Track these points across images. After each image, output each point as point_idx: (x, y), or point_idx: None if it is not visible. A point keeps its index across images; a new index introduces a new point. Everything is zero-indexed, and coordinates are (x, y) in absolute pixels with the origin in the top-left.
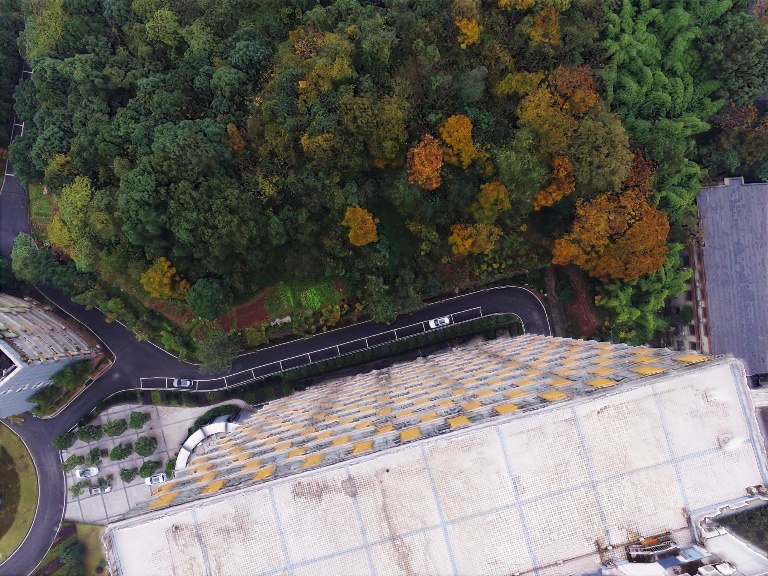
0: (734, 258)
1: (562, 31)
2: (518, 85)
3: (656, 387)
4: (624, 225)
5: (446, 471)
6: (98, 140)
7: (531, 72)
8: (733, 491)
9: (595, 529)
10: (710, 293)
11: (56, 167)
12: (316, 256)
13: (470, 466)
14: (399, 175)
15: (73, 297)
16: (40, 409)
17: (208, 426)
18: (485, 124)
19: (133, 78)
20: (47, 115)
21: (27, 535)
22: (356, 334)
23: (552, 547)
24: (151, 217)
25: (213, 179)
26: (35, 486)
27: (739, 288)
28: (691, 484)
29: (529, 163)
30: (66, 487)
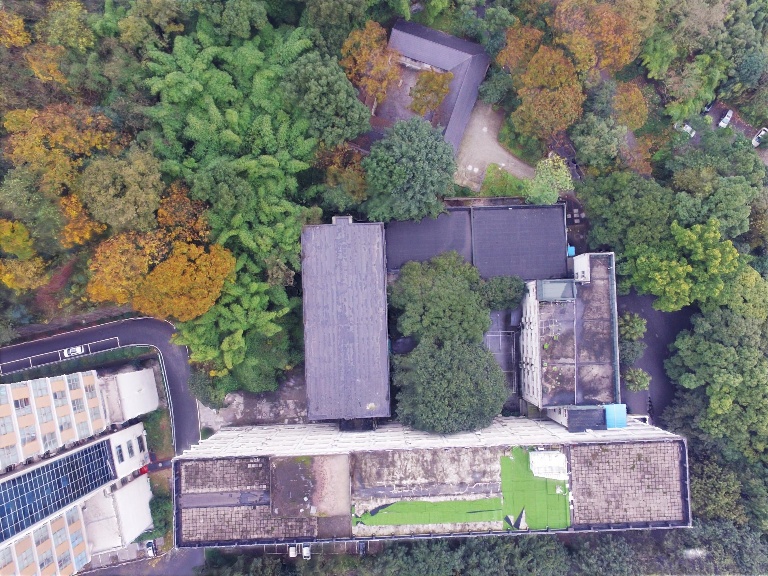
0: (336, 299)
1: (103, 68)
2: (9, 123)
3: None
4: (144, 266)
5: None
6: None
7: None
8: None
9: None
10: (310, 333)
11: None
12: None
13: None
14: None
15: None
16: None
17: None
18: None
19: None
20: None
21: None
22: None
23: None
24: None
25: None
26: None
27: (339, 329)
28: None
29: (29, 202)
30: None
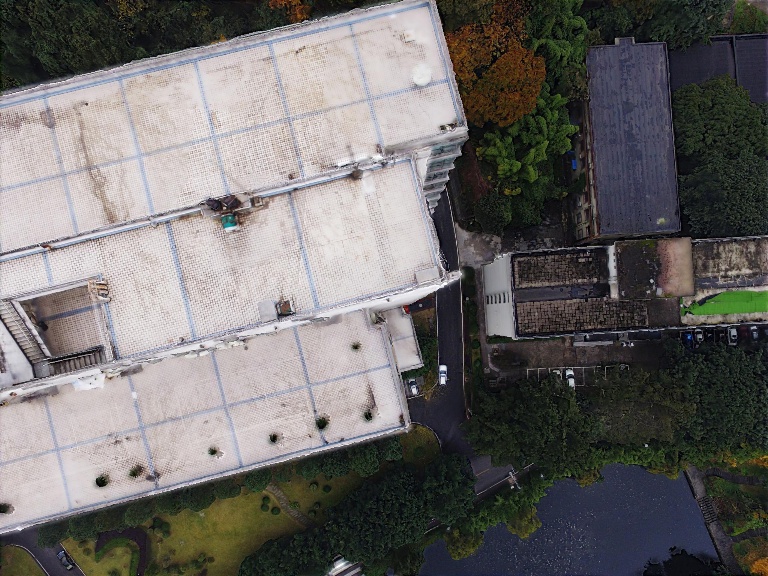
0: (623, 117)
1: None
2: None
3: (355, 28)
4: (489, 57)
5: (144, 105)
6: None
7: None
8: (428, 129)
9: (290, 164)
10: (598, 152)
11: None
12: None
13: (168, 101)
14: (262, 3)
15: None
16: None
17: None
18: None
19: None
20: None
21: None
22: None
23: (246, 180)
24: (13, 39)
25: (75, 3)
26: None
27: (627, 147)
28: (386, 121)
29: None
30: None
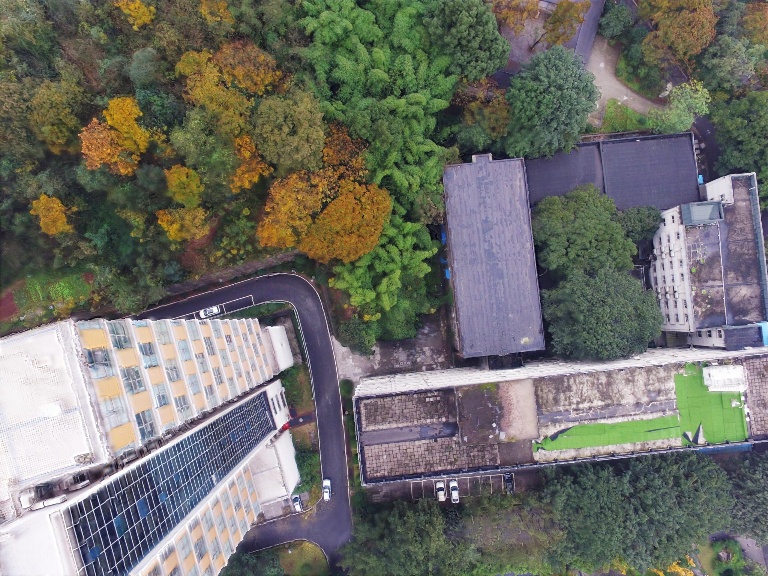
0: (482, 236)
1: (257, 10)
2: (184, 65)
3: None
4: (318, 204)
5: None
6: None
7: (200, 51)
8: (62, 460)
9: None
10: (459, 273)
11: None
12: (46, 248)
13: None
14: (81, 161)
15: None
16: None
17: None
18: (157, 106)
19: None
20: None
21: None
22: None
23: None
24: None
25: None
26: None
27: (488, 267)
28: (18, 454)
29: (206, 144)
30: None
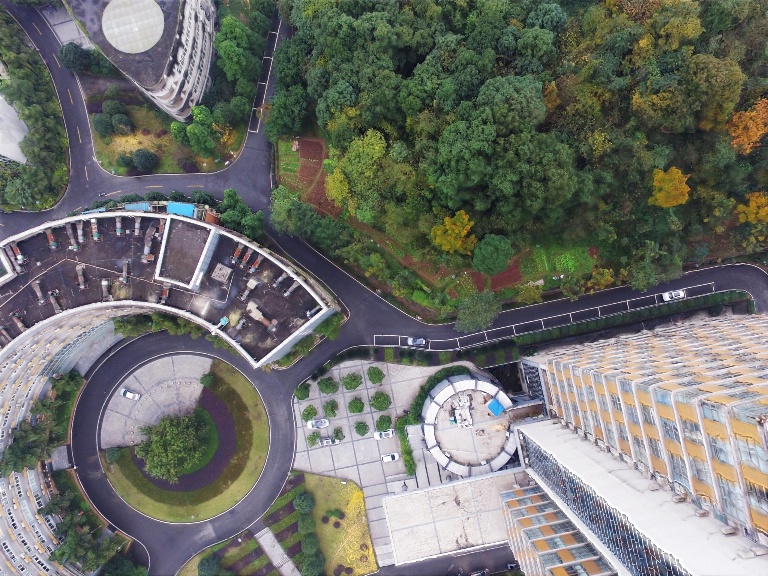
0: None
1: None
2: None
3: None
4: None
5: None
6: (405, 94)
7: None
8: None
9: None
10: None
11: (346, 120)
12: (588, 220)
13: None
14: (717, 139)
15: (339, 249)
16: (289, 358)
17: (458, 383)
18: None
19: (420, 37)
20: (334, 70)
21: (257, 481)
22: (589, 303)
23: None
24: (481, 167)
25: (541, 133)
26: (267, 434)
27: None
28: None
29: None
30: (296, 437)
